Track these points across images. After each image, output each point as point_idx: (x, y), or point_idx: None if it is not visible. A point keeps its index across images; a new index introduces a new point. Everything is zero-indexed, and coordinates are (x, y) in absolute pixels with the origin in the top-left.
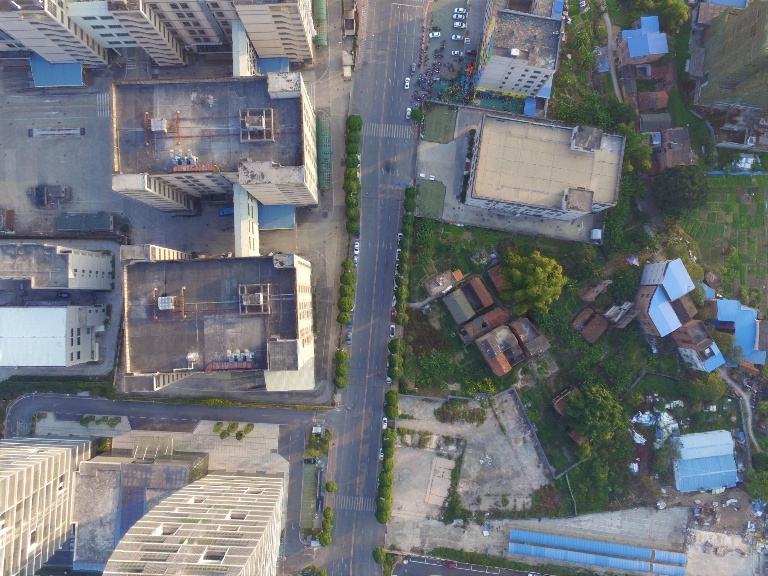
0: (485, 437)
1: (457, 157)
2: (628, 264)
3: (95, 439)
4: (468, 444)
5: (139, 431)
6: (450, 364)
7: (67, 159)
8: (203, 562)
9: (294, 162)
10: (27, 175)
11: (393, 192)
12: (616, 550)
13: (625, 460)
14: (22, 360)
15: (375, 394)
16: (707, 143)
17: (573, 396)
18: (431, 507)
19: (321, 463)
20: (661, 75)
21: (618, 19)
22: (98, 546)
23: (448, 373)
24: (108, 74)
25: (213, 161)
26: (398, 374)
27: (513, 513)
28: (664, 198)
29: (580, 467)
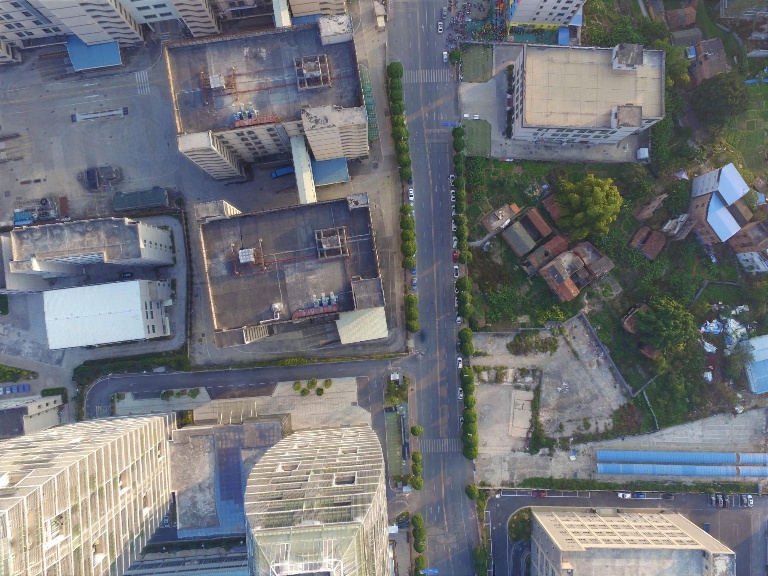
0: (560, 364)
1: (498, 94)
2: (677, 179)
3: (178, 412)
4: (544, 373)
5: (219, 400)
6: (518, 296)
7: (113, 140)
8: (337, 485)
9: (353, 105)
10: (75, 160)
11: (440, 136)
12: (702, 458)
13: (699, 370)
14: (101, 337)
15: (447, 336)
16: (739, 52)
17: (643, 311)
18: (515, 440)
19: (402, 410)
20: None
21: None
22: (200, 512)
23: (516, 306)
24: (144, 51)
25: (273, 113)
26: (470, 310)
27: (596, 435)
28: (706, 109)
29: (656, 382)
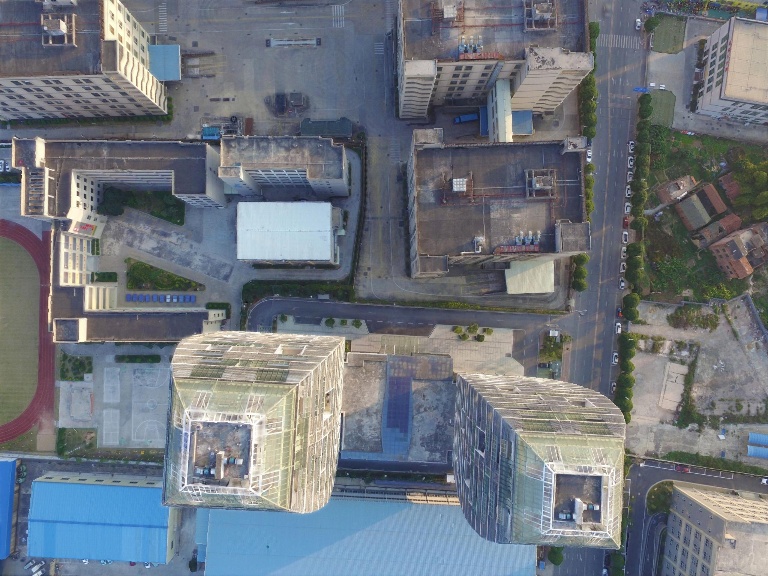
0: (718, 343)
1: (686, 67)
2: None
3: None
4: (701, 349)
5: (377, 334)
6: (687, 268)
7: (304, 69)
8: None
9: (575, 51)
10: (265, 84)
11: (623, 101)
12: None
13: None
14: (288, 253)
15: (608, 300)
16: None
17: None
18: (665, 412)
19: (555, 368)
20: None
21: None
22: (365, 436)
23: (682, 279)
24: None
25: (496, 50)
26: (641, 276)
27: (747, 418)
28: None
29: None
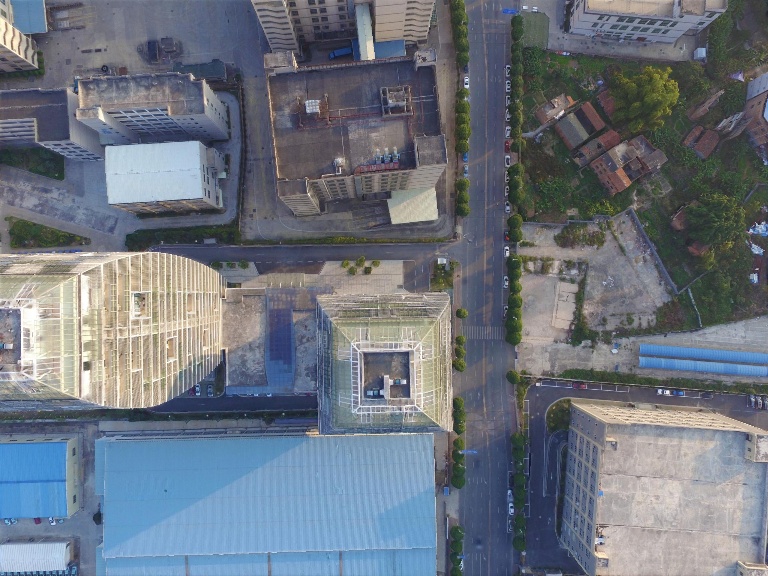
0: (606, 259)
1: None
2: None
3: None
4: (590, 267)
5: None
6: (569, 186)
7: (175, 14)
8: None
9: None
10: (136, 32)
11: (497, 26)
12: (744, 356)
13: (745, 271)
14: (159, 194)
15: (495, 225)
16: None
17: (694, 206)
18: (558, 331)
19: None
20: None
21: None
22: (249, 370)
23: (566, 198)
24: None
25: None
26: (521, 196)
27: (639, 331)
28: (766, 10)
29: (701, 281)
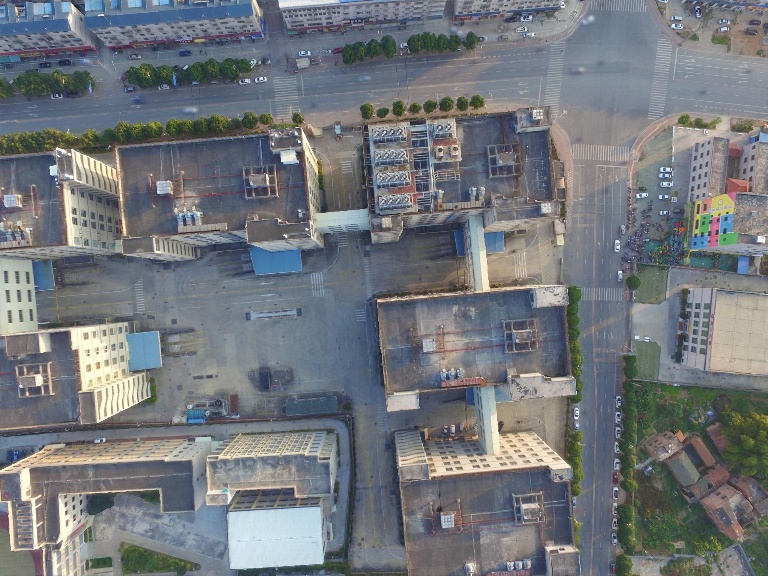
0: None
1: (670, 317)
2: None
3: None
4: None
5: None
6: (678, 526)
7: (286, 340)
8: None
9: (557, 369)
10: (247, 359)
11: (608, 355)
12: None
13: None
14: (281, 561)
15: (601, 555)
16: None
17: None
18: None
19: None
20: None
21: None
22: None
23: None
24: (321, 253)
25: (478, 372)
26: (633, 543)
27: None
28: None
29: None
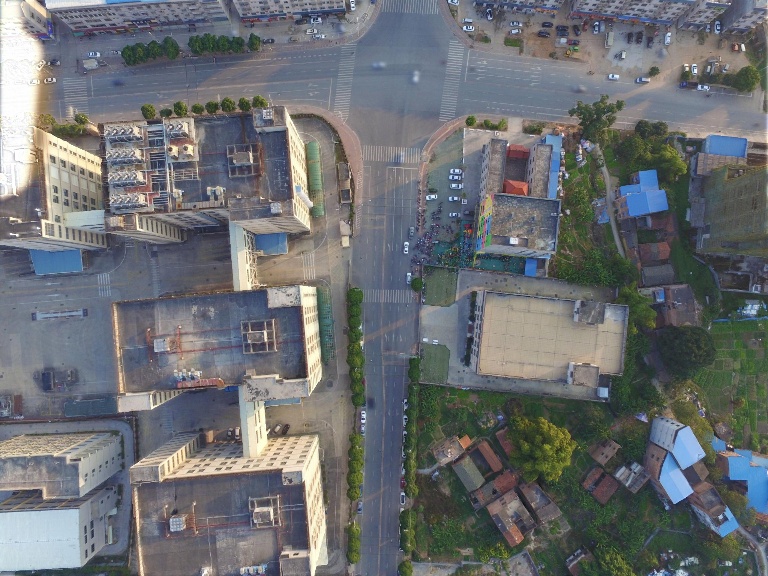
0: None
1: (459, 320)
2: (636, 419)
3: None
4: None
5: None
6: (462, 533)
7: (71, 341)
8: None
9: (298, 370)
10: (33, 359)
11: (397, 358)
12: None
13: None
14: (38, 564)
15: (388, 562)
16: (711, 295)
17: (587, 563)
18: None
19: None
20: (662, 226)
21: (616, 169)
22: None
23: None
24: (107, 254)
25: (217, 373)
26: (410, 549)
27: None
28: (670, 357)
29: None
